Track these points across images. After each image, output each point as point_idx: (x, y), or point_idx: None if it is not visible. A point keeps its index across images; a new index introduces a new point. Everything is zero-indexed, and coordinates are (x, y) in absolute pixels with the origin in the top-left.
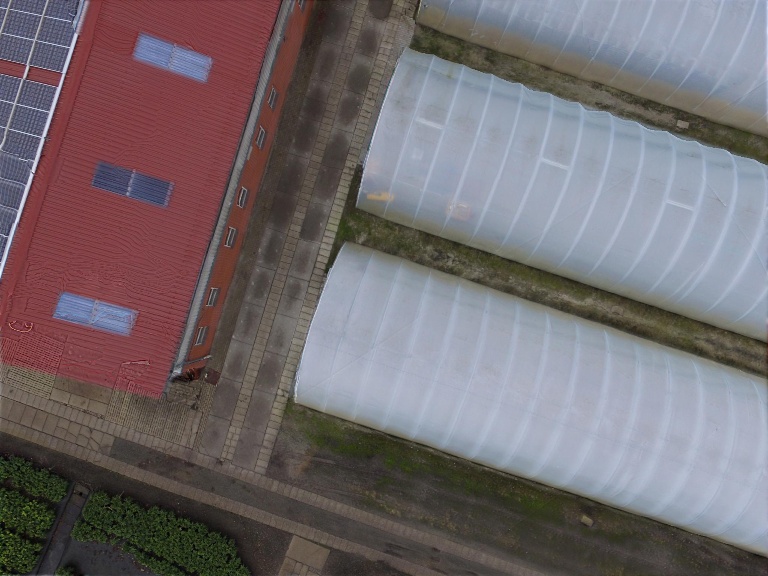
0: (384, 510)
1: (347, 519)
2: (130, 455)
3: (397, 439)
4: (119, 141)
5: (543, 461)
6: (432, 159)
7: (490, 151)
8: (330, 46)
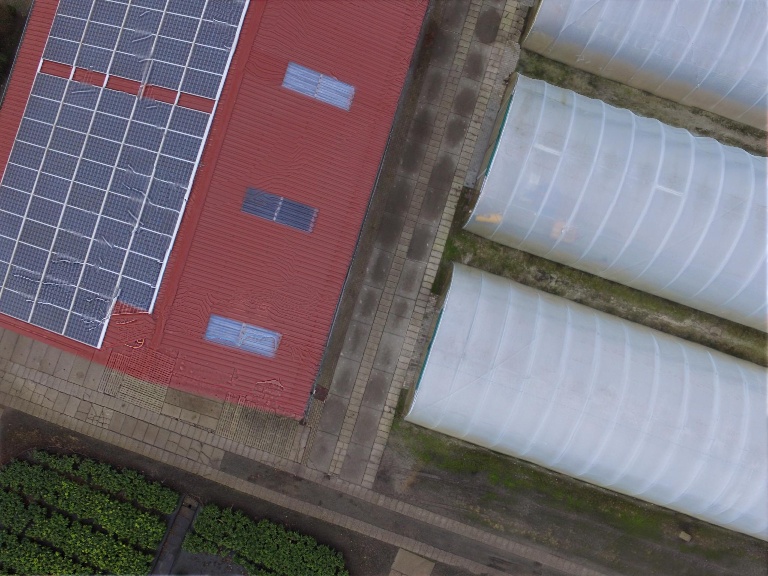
0: (488, 524)
1: (452, 533)
2: (240, 469)
3: (501, 455)
4: (260, 168)
5: (653, 479)
6: (549, 185)
7: (607, 177)
8: (437, 70)
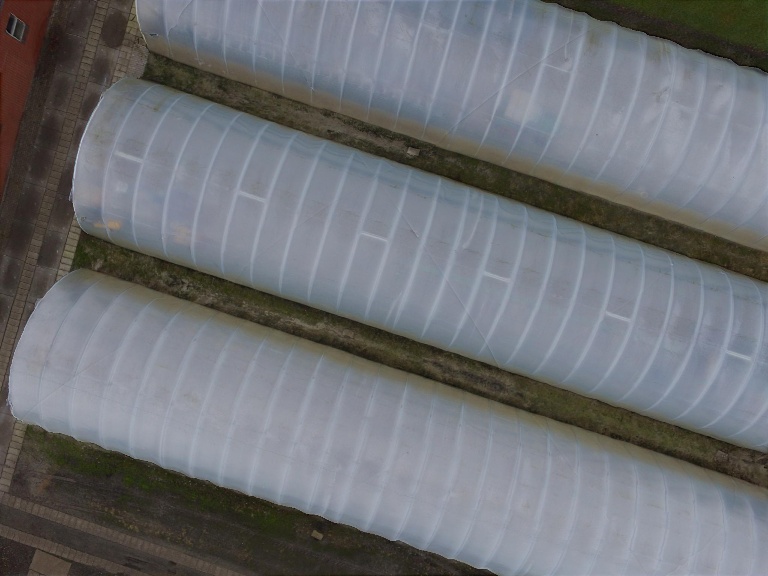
0: (122, 525)
1: (87, 534)
2: None
3: None
4: None
5: (249, 482)
6: (134, 192)
7: (188, 184)
8: (64, 75)
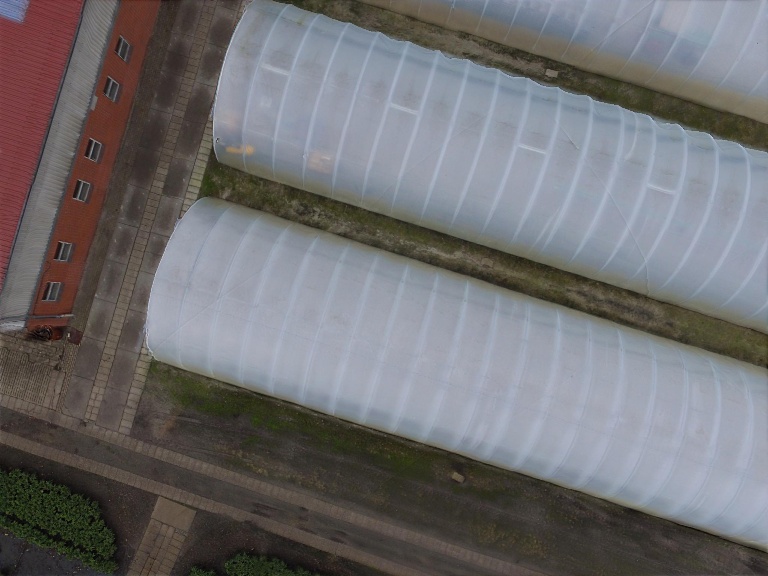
0: (251, 469)
1: (213, 479)
2: None
3: (263, 397)
4: None
5: (399, 412)
6: (279, 106)
7: (337, 96)
8: None
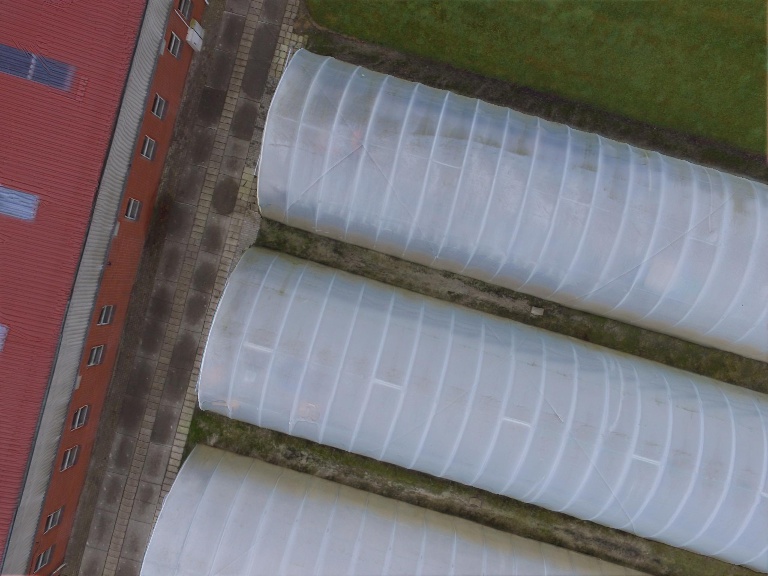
0: None
1: None
2: None
3: None
4: None
5: None
6: (264, 382)
7: (321, 374)
8: (174, 244)
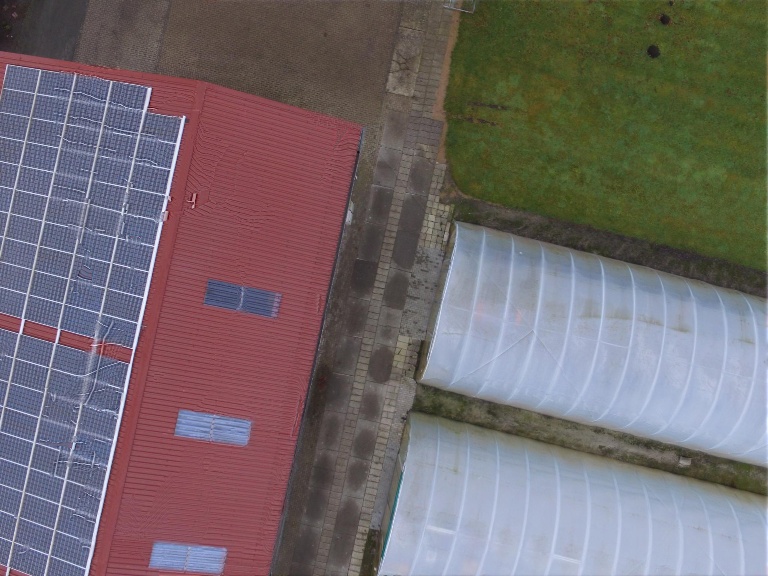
0: None
1: None
2: None
3: None
4: None
5: None
6: (446, 563)
7: (502, 553)
8: (333, 414)
